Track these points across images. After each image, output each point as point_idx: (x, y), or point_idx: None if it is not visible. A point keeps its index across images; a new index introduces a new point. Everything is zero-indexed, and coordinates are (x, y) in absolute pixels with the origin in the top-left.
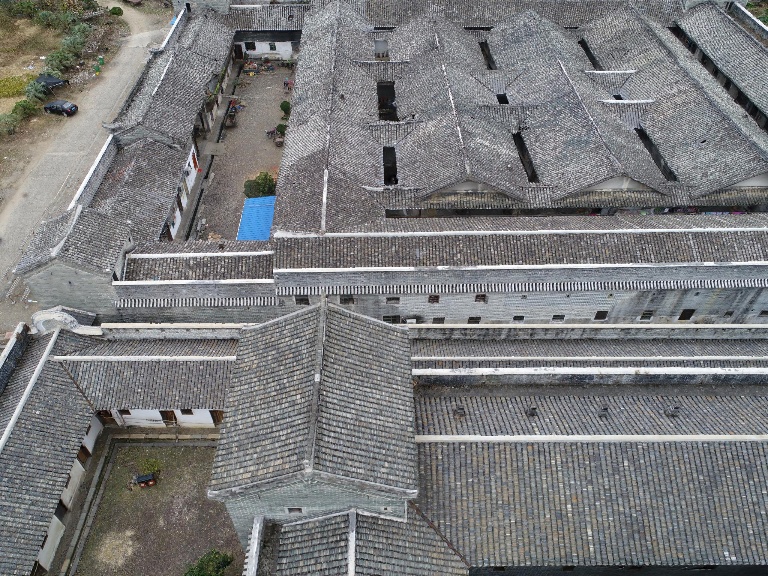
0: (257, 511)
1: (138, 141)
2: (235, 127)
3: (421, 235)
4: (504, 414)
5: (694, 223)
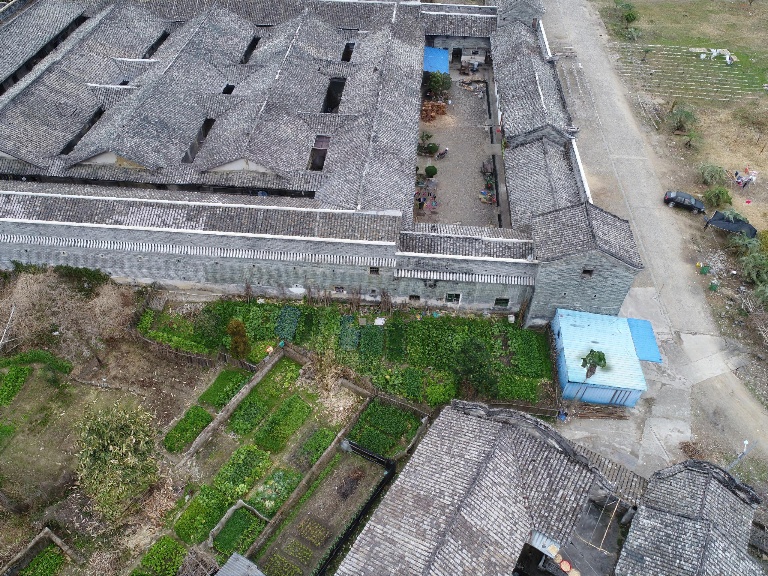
0: None
1: None
2: None
3: None
4: None
5: (192, 6)
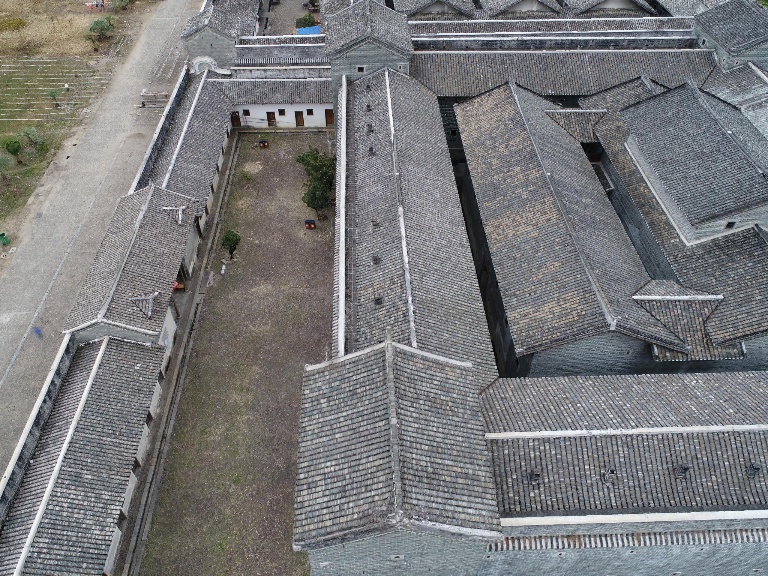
0: (344, 70)
1: None
2: (279, 4)
3: (411, 23)
4: None
5: None
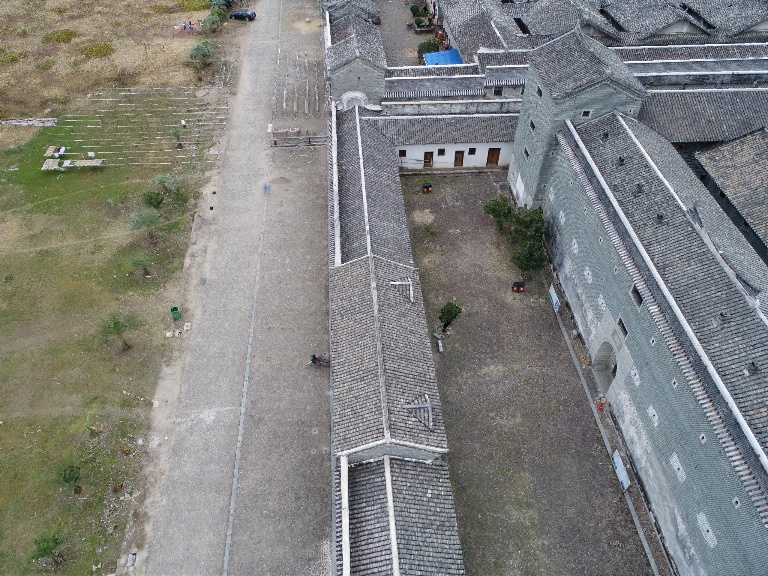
0: (568, 114)
1: (345, 16)
2: (380, 24)
3: None
4: None
5: None
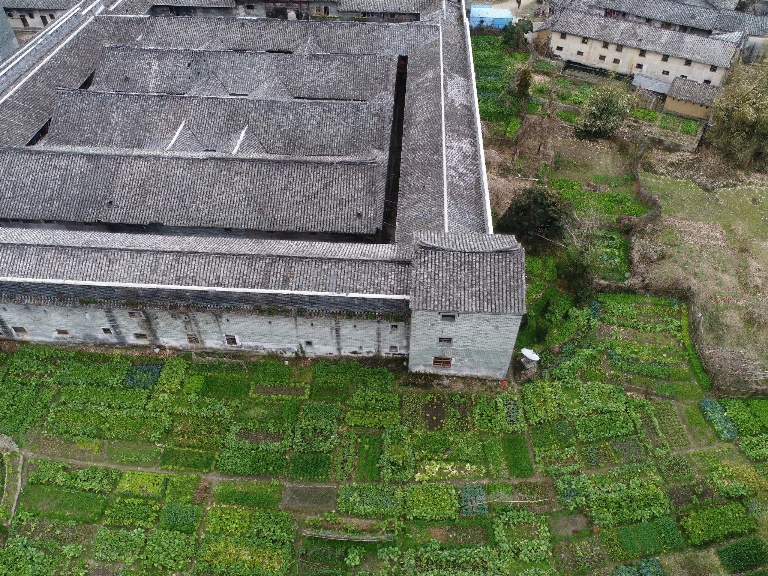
0: None
1: None
2: None
3: None
4: None
5: (3, 129)
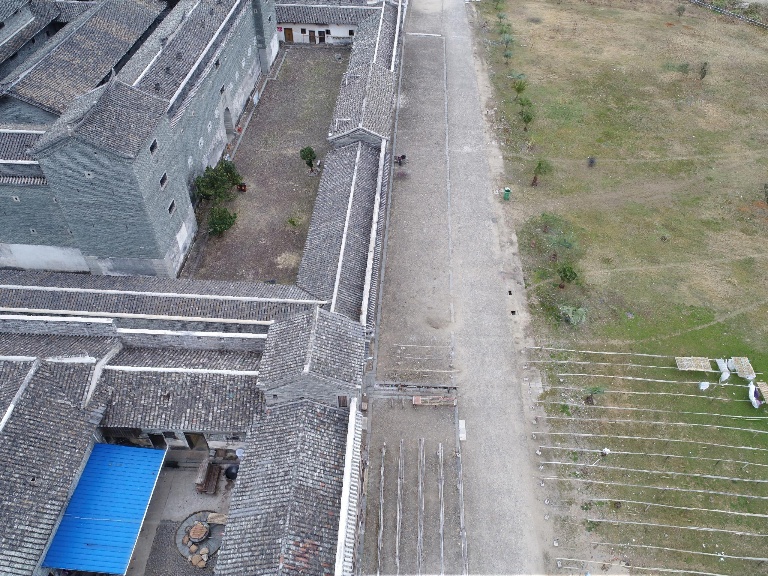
0: None
1: None
2: None
3: None
4: (5, 151)
5: None
